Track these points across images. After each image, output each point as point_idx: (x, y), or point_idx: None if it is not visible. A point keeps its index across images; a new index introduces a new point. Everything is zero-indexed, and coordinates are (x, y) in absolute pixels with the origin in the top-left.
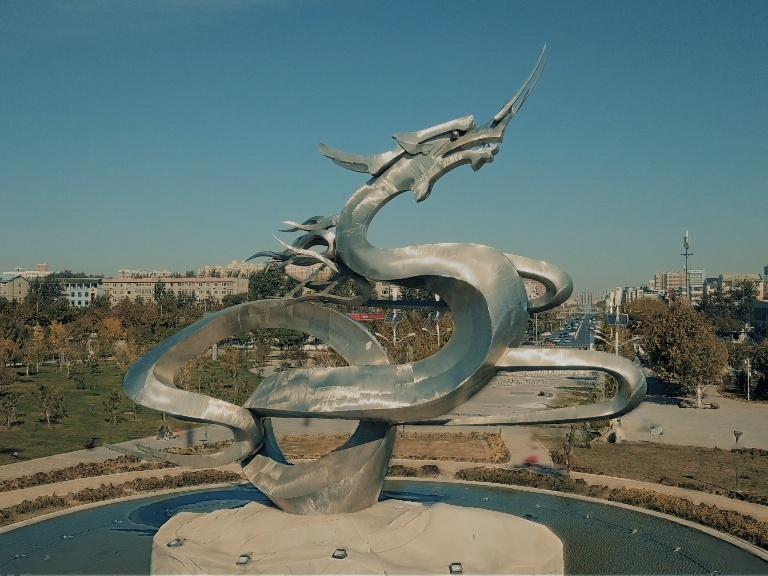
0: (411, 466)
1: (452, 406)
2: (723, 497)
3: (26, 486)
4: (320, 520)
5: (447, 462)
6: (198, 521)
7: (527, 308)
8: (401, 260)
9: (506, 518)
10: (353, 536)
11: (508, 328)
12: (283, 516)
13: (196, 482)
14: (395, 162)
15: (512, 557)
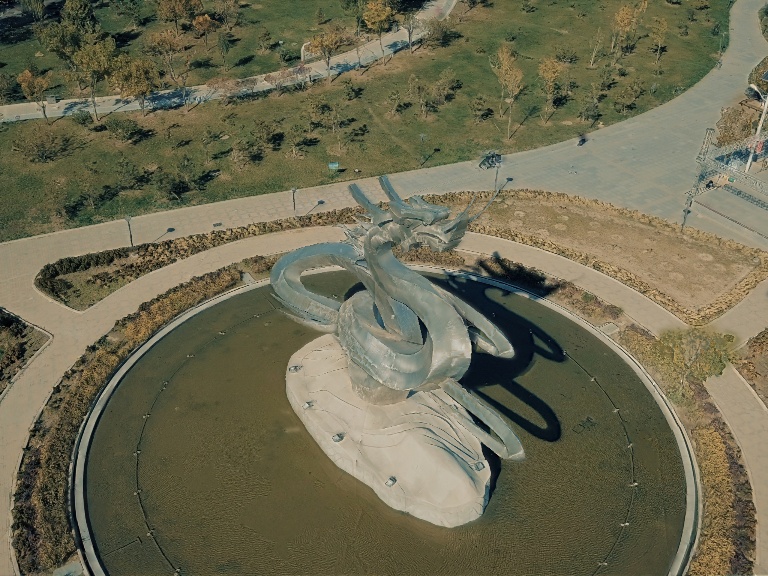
0: (609, 297)
1: (418, 390)
2: None
3: (327, 224)
4: (355, 402)
5: (649, 301)
6: (321, 353)
7: (485, 350)
8: (395, 286)
9: (442, 466)
10: (359, 426)
11: (449, 367)
12: (348, 383)
13: (425, 260)
14: (391, 221)
15: (429, 492)
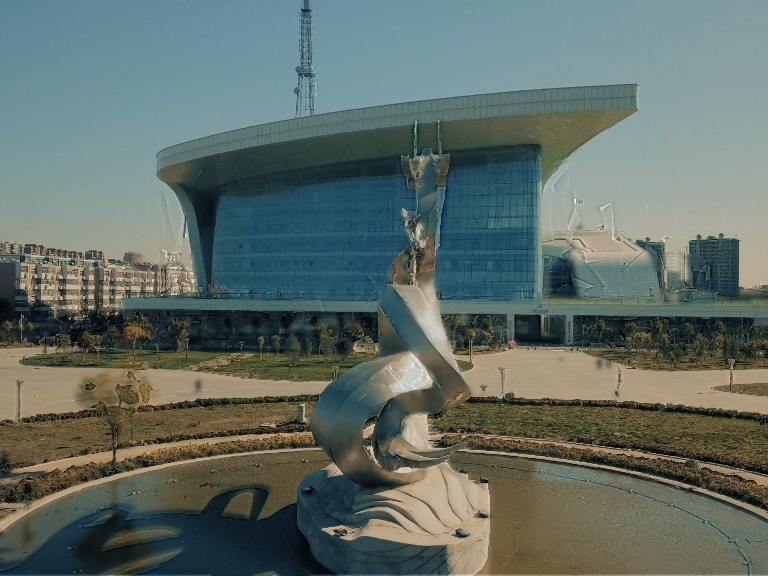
0: None
1: None
2: (158, 444)
3: None
4: None
5: None
6: None
7: None
8: None
9: None
10: None
11: None
12: (422, 485)
13: None
14: None
15: None
